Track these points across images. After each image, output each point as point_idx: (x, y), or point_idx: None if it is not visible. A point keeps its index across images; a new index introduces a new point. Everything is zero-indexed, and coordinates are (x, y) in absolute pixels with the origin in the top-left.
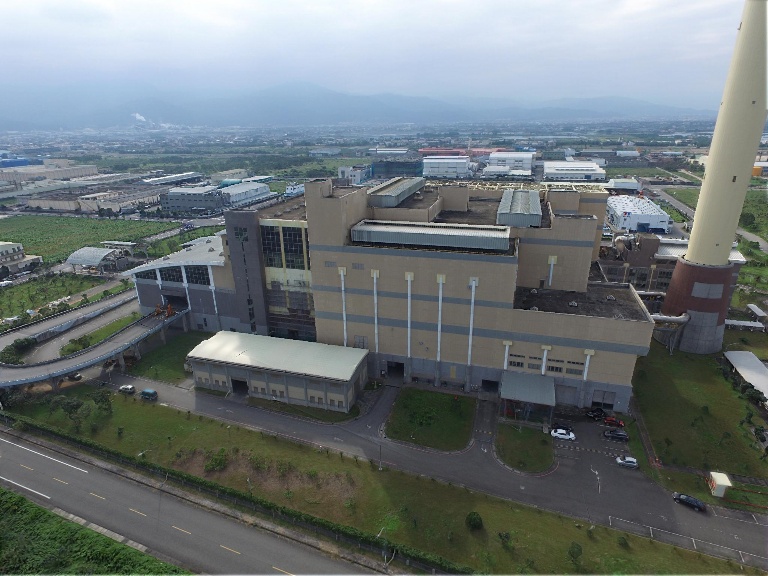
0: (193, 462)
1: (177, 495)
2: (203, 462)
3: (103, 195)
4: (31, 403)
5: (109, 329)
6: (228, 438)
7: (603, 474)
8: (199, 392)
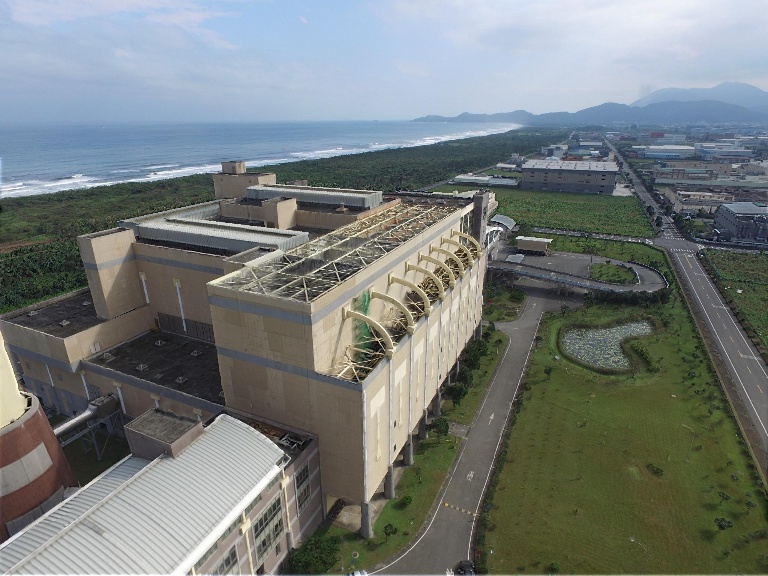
0: None
1: None
2: None
3: (702, 195)
4: None
5: None
6: None
7: (14, 364)
8: None
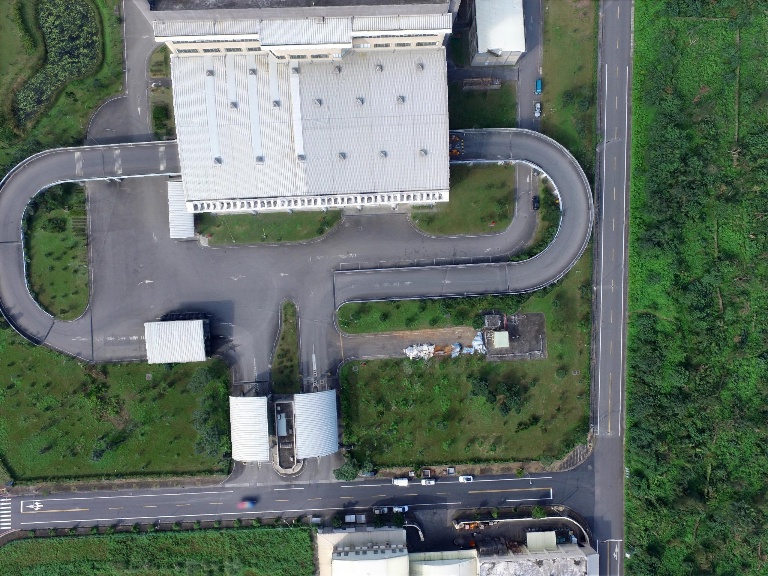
0: (582, 7)
1: (603, 1)
2: (581, 1)
3: None
4: (585, 146)
5: (460, 222)
6: (558, 0)
7: None
8: (519, 57)
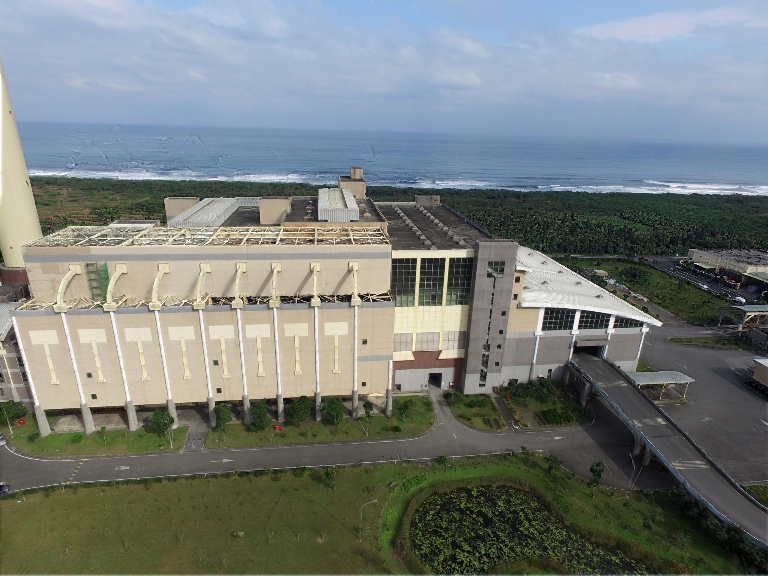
0: None
1: None
2: None
3: None
4: None
5: None
6: None
7: None
8: None
